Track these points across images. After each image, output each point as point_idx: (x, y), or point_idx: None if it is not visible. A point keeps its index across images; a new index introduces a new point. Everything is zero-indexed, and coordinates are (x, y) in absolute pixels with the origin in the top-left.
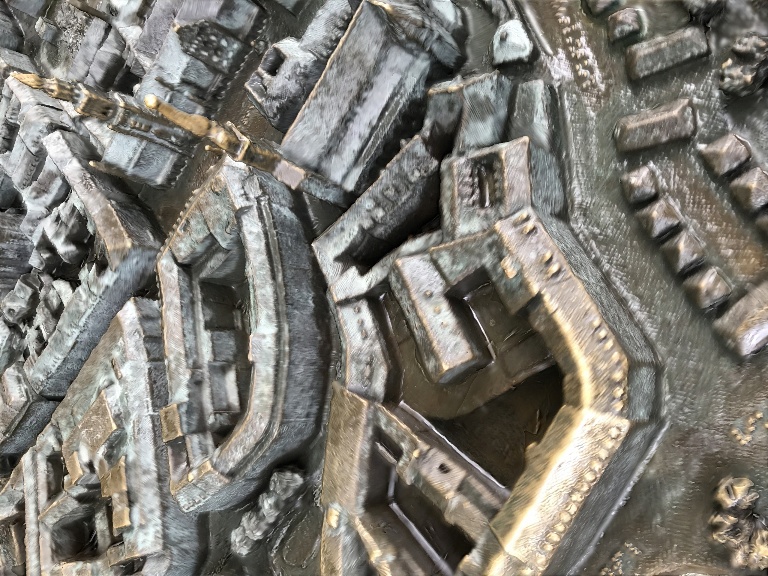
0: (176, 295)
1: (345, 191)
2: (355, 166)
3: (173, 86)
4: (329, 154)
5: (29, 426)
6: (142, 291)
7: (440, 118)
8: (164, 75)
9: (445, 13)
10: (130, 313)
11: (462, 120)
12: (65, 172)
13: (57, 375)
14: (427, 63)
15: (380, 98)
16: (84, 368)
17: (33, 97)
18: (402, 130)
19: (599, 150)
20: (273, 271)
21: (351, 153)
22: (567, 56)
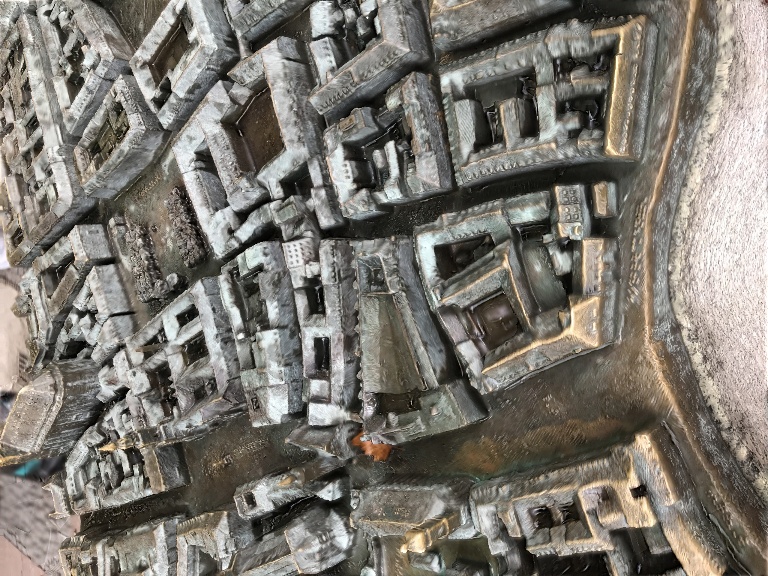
0: (185, 560)
1: None
2: None
3: (197, 426)
4: None
5: None
6: None
7: None
8: (192, 422)
9: (342, 543)
10: (161, 533)
11: None
12: (127, 402)
13: None
14: None
15: None
16: (133, 539)
17: (107, 308)
18: None
19: None
20: None
21: (281, 575)
22: None
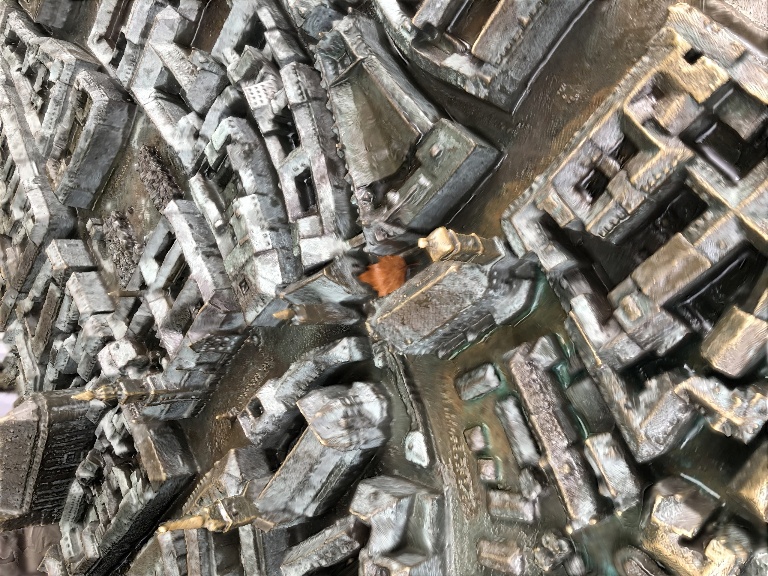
0: (196, 548)
1: (306, 516)
2: (313, 502)
3: (190, 369)
4: (293, 498)
5: (102, 567)
6: (177, 494)
7: (360, 519)
8: (183, 363)
9: (373, 412)
10: (166, 537)
11: (371, 535)
12: None
13: (119, 543)
14: (359, 449)
15: (327, 468)
16: (137, 564)
17: (89, 306)
18: (346, 478)
19: (469, 550)
20: (259, 562)
21: (309, 497)
22: (453, 470)
